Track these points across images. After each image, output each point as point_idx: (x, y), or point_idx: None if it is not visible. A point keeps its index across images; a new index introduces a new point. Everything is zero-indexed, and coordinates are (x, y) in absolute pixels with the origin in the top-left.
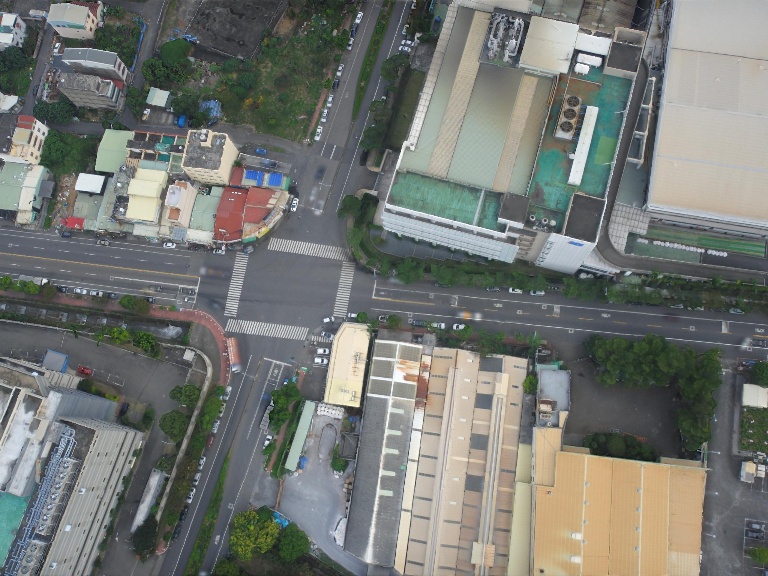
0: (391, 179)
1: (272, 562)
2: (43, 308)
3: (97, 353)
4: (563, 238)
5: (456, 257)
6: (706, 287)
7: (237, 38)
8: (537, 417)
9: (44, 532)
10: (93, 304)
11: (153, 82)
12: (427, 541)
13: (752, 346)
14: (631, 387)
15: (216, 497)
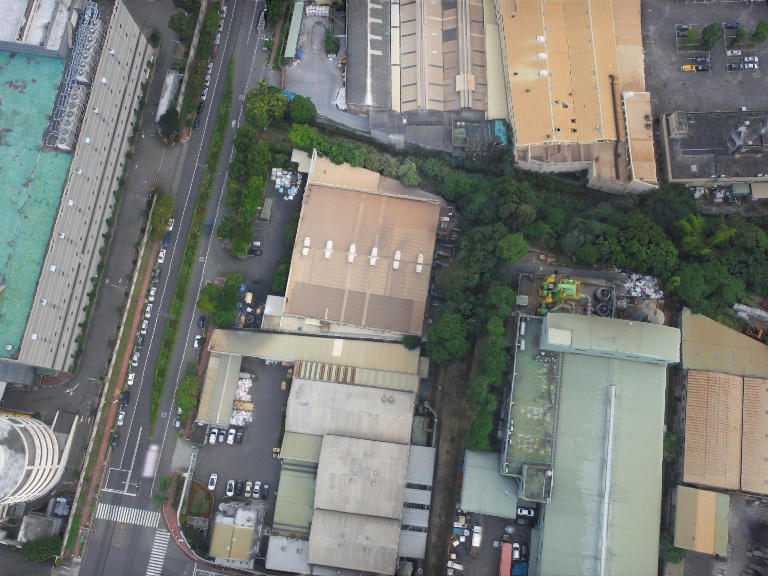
0: None
1: (285, 132)
2: None
3: None
4: None
5: None
6: None
7: None
8: None
9: (84, 76)
10: None
11: None
12: (417, 80)
13: None
14: None
15: (227, 90)
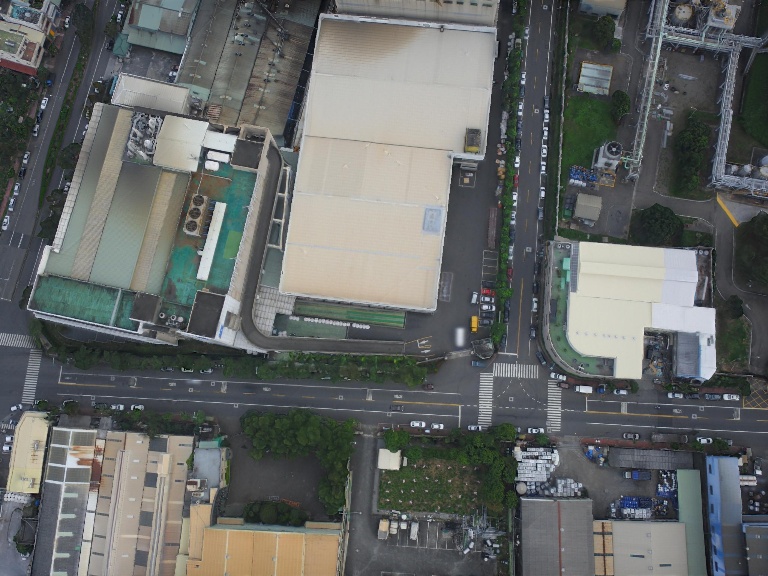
0: None
1: None
2: None
3: None
4: None
5: None
6: (347, 360)
7: None
8: None
9: None
10: None
11: None
12: None
13: (391, 412)
14: None
15: None
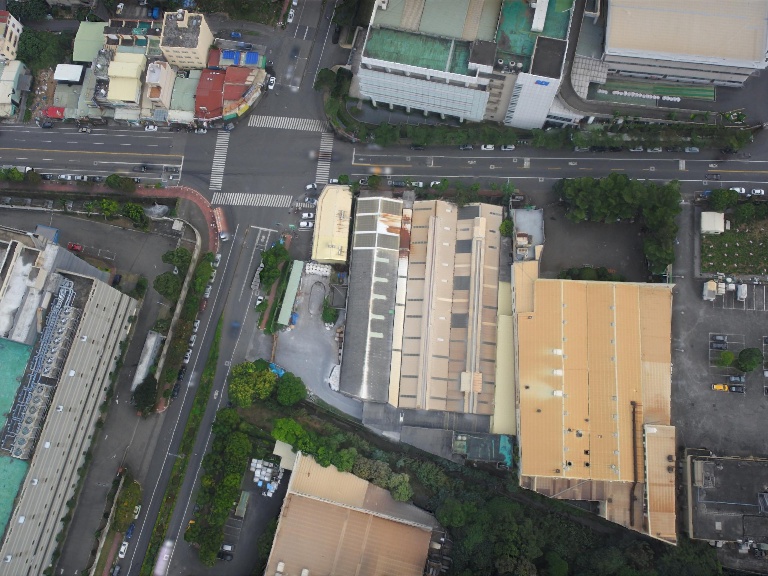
0: None
1: (271, 411)
2: (28, 197)
3: (86, 230)
4: (530, 77)
5: (429, 122)
6: (663, 128)
7: None
8: (514, 256)
9: (49, 374)
10: (78, 188)
11: None
12: (418, 374)
13: (707, 180)
14: (599, 226)
15: (212, 355)
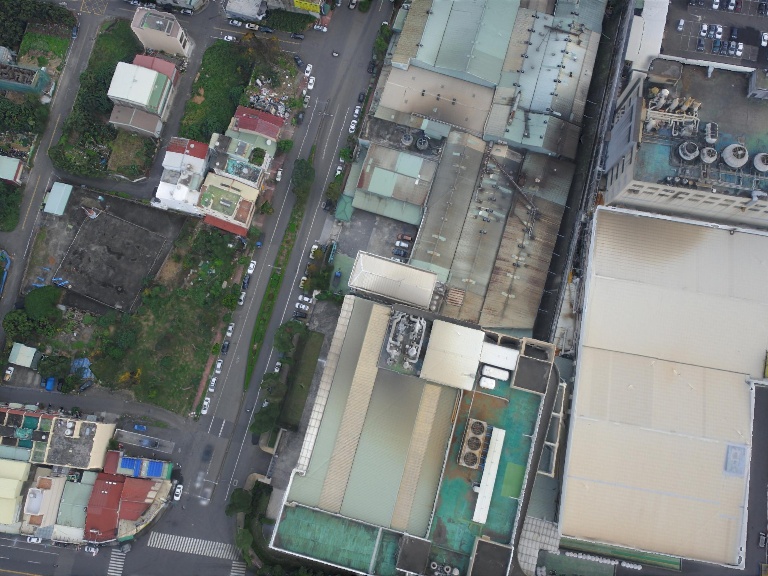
0: (286, 462)
1: None
2: None
3: None
4: None
5: None
6: None
7: (115, 283)
8: None
9: None
10: None
11: (17, 336)
12: None
13: None
14: None
15: None
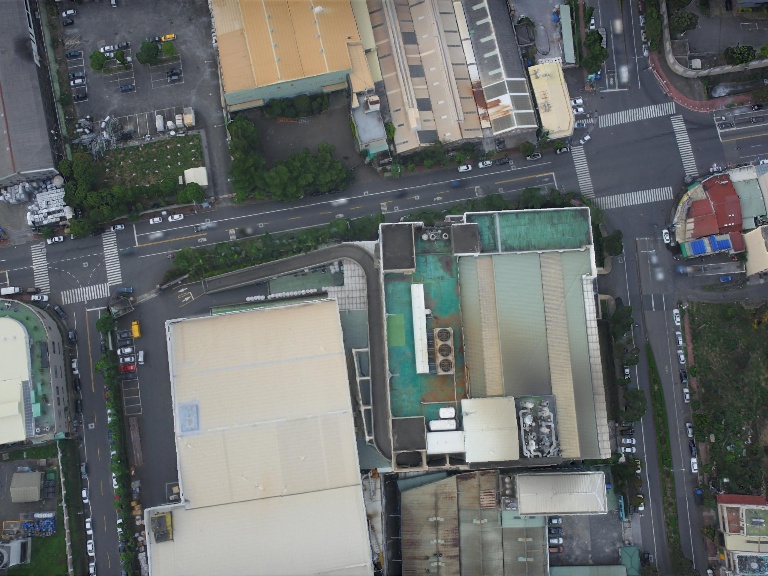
0: None
1: None
2: None
3: None
4: None
5: None
6: (260, 259)
7: None
8: None
9: None
10: None
11: None
12: None
13: (206, 224)
14: None
15: None
